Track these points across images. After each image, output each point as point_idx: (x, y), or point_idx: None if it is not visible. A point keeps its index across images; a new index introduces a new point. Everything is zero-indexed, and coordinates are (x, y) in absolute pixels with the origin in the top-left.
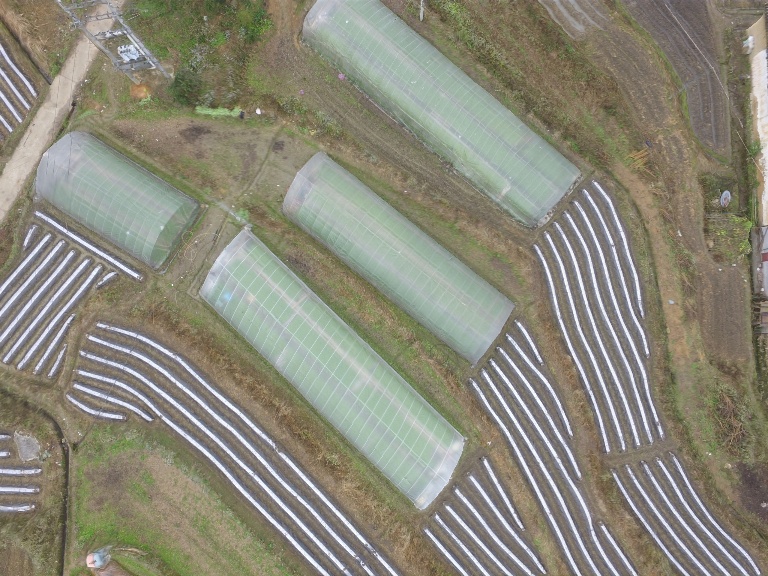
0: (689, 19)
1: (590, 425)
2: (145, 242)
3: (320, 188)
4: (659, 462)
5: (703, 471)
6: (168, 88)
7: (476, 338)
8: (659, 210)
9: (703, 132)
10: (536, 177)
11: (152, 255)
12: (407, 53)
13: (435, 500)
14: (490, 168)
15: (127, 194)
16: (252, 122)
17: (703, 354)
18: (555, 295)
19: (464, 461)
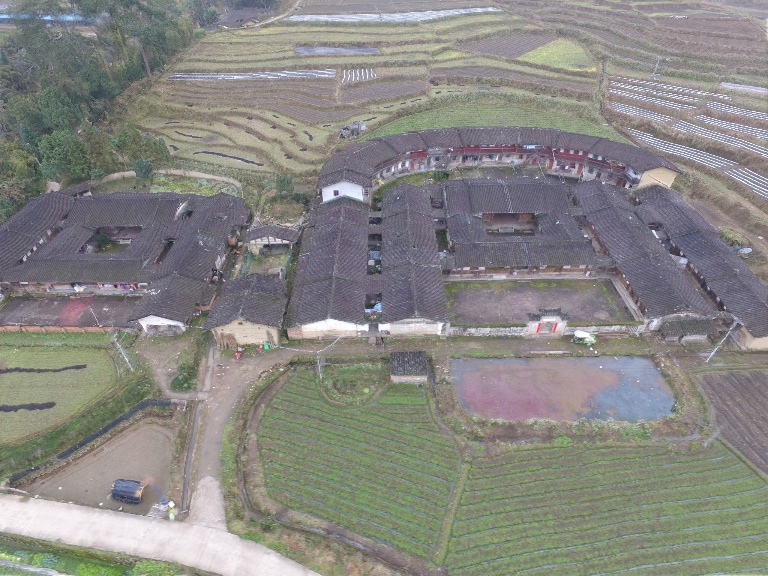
0: None
1: None
2: None
3: None
4: None
5: (697, 166)
6: None
7: None
8: None
9: None
10: None
11: None
12: None
13: None
14: None
15: None
16: None
17: None
18: None
19: None
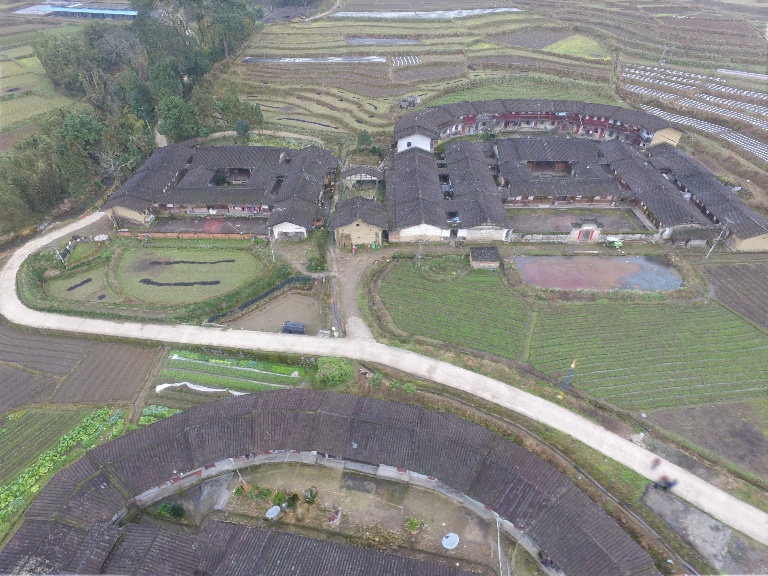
0: None
1: None
2: None
3: None
4: None
5: (698, 131)
6: None
7: None
8: None
9: (759, 215)
10: None
11: None
12: None
13: None
14: None
15: None
16: None
17: None
18: None
19: None
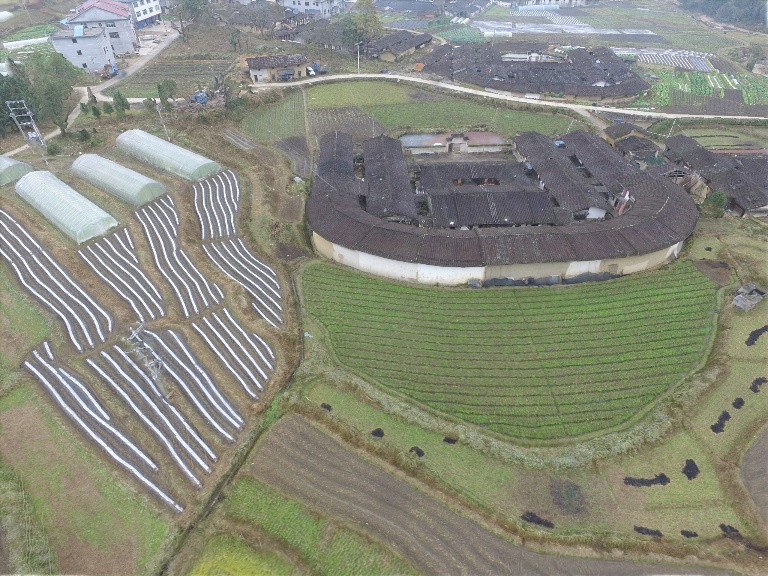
0: (299, 148)
1: (190, 222)
2: (0, 170)
3: (89, 157)
4: (230, 240)
5: None
6: (47, 154)
7: (136, 188)
8: (259, 178)
9: None
10: (193, 161)
11: (1, 177)
12: (153, 140)
13: (91, 243)
14: (176, 162)
15: (3, 159)
16: (77, 157)
17: (269, 213)
18: (196, 197)
19: (114, 230)
